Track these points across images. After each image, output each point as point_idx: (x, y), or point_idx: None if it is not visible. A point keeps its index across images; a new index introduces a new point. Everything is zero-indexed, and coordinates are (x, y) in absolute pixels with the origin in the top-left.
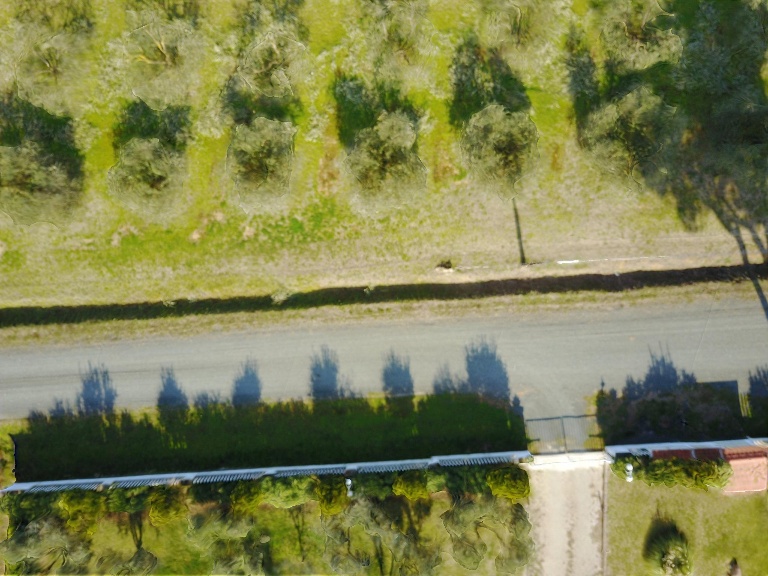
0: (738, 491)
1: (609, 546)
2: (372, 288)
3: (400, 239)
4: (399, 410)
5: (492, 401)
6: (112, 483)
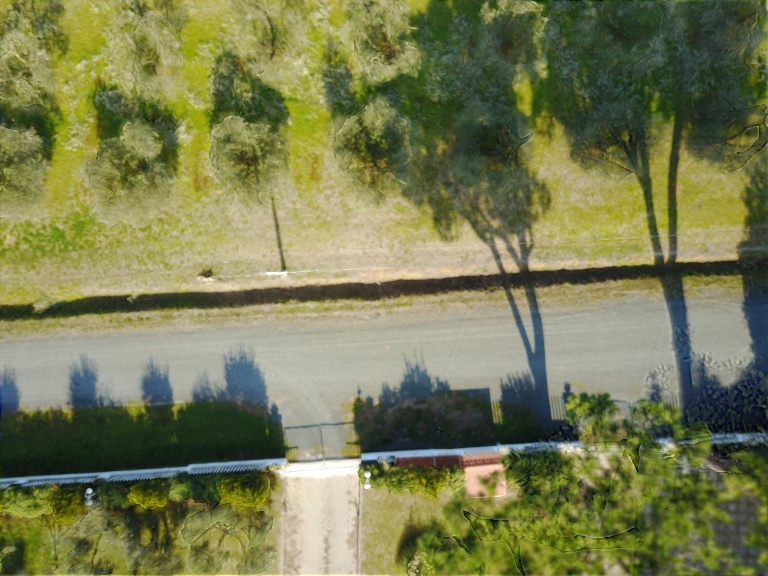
0: (479, 497)
1: (364, 552)
2: (135, 297)
3: (162, 248)
4: (159, 418)
5: (251, 409)
6: None
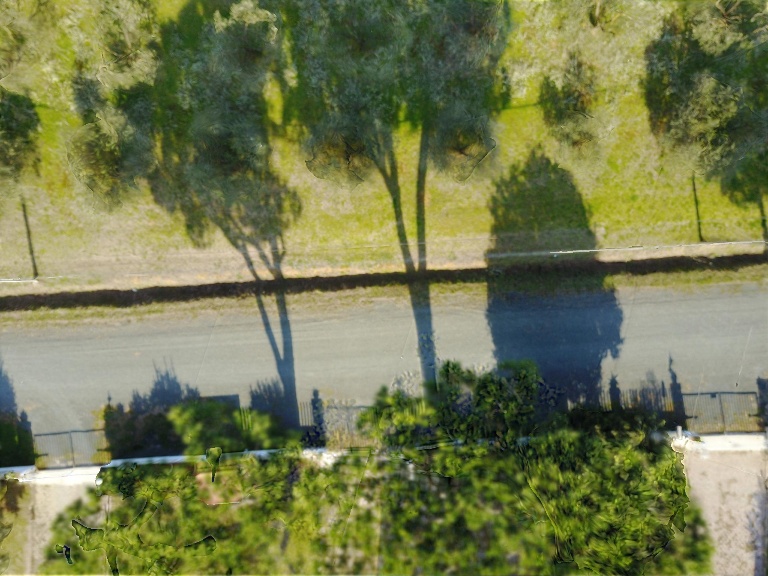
0: (217, 503)
1: None
2: None
3: None
4: None
5: None
6: None
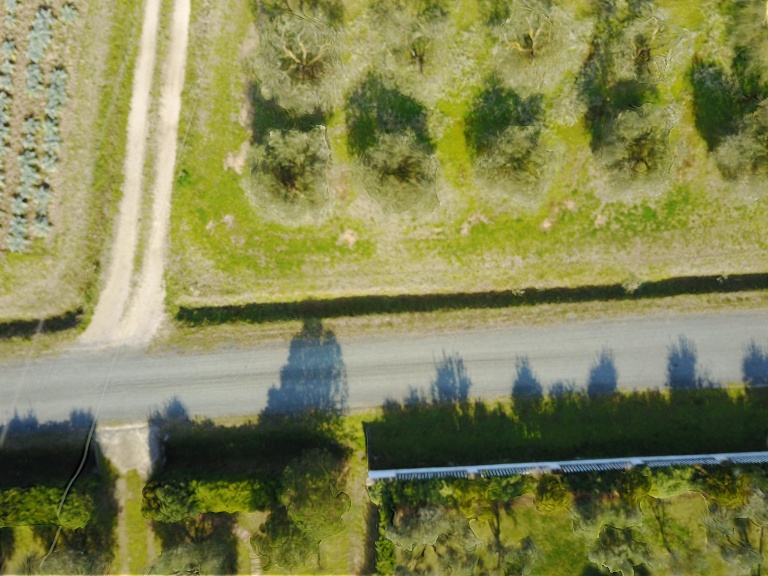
0: None
1: None
2: (726, 277)
3: (757, 227)
4: (759, 401)
5: None
6: (478, 471)
